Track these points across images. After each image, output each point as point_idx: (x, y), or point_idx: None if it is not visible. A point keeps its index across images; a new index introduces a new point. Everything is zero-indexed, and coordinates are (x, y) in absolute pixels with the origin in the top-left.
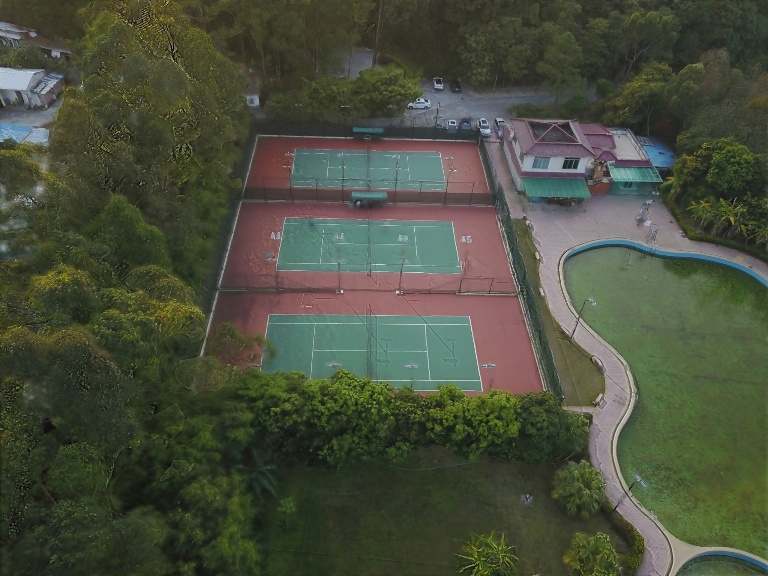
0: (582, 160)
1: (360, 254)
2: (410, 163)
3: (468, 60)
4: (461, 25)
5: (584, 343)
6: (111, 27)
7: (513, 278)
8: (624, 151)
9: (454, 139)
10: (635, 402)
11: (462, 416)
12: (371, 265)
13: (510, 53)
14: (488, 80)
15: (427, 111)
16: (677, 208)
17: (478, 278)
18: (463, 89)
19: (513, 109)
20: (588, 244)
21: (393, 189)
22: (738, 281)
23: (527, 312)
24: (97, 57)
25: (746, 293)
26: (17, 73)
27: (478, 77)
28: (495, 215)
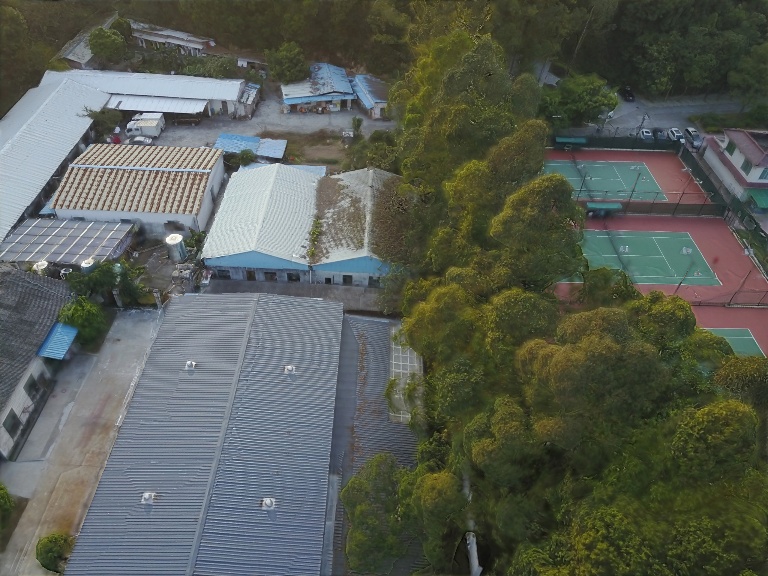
0: None
1: (614, 265)
2: (620, 173)
3: (649, 69)
4: (638, 34)
5: None
6: (480, 45)
7: None
8: None
9: (652, 149)
10: None
11: None
12: (629, 277)
13: (695, 63)
14: (666, 89)
15: (610, 120)
16: None
17: (754, 291)
18: (635, 98)
19: (694, 118)
20: None
21: (627, 200)
22: None
23: None
24: (468, 75)
25: None
26: (224, 83)
27: (659, 86)
28: (727, 226)
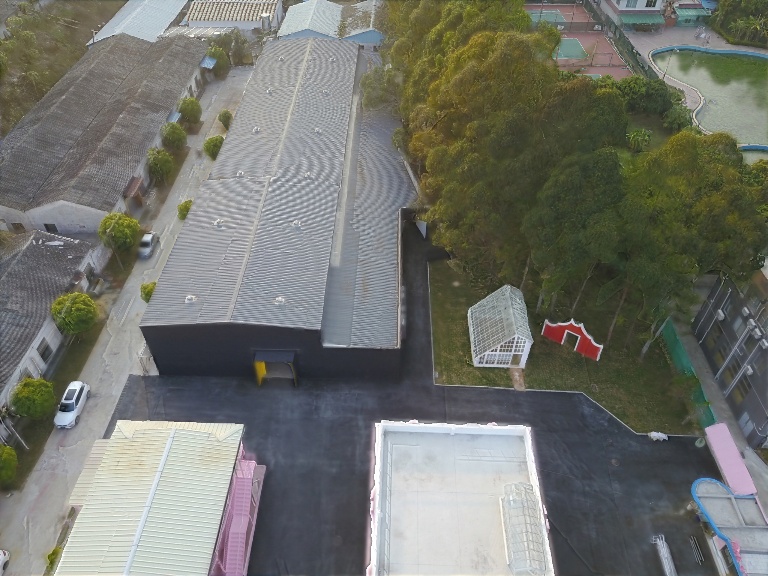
0: (659, 0)
1: None
2: None
3: None
4: None
5: (670, 83)
6: None
7: (622, 60)
8: (684, 1)
9: (566, 3)
10: (703, 103)
11: (615, 86)
12: None
13: None
14: None
15: None
16: (722, 30)
17: (604, 53)
18: None
19: None
20: (665, 48)
21: None
22: (763, 63)
23: (634, 72)
24: None
25: (767, 66)
26: None
27: None
28: (603, 35)
